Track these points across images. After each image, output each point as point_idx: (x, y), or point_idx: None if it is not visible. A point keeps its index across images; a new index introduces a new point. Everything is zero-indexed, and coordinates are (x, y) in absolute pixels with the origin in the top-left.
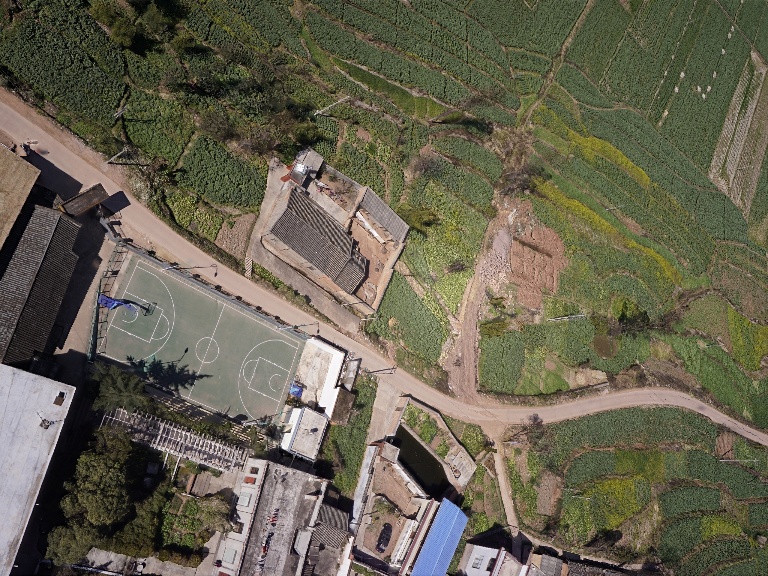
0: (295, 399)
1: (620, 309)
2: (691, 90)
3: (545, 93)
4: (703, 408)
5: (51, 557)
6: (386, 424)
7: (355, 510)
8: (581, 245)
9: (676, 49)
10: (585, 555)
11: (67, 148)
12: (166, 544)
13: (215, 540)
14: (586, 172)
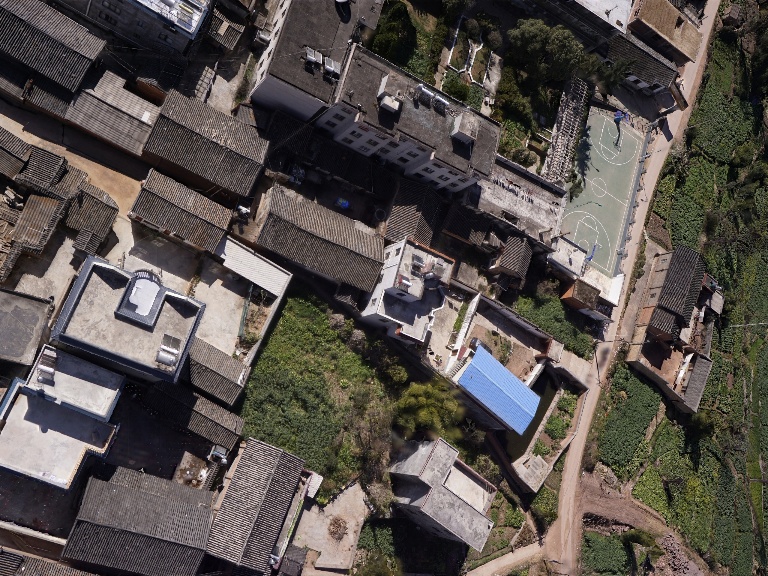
0: None
1: None
2: None
3: None
4: None
5: (514, 28)
6: None
7: None
8: None
9: None
10: None
11: None
12: None
13: None
14: None
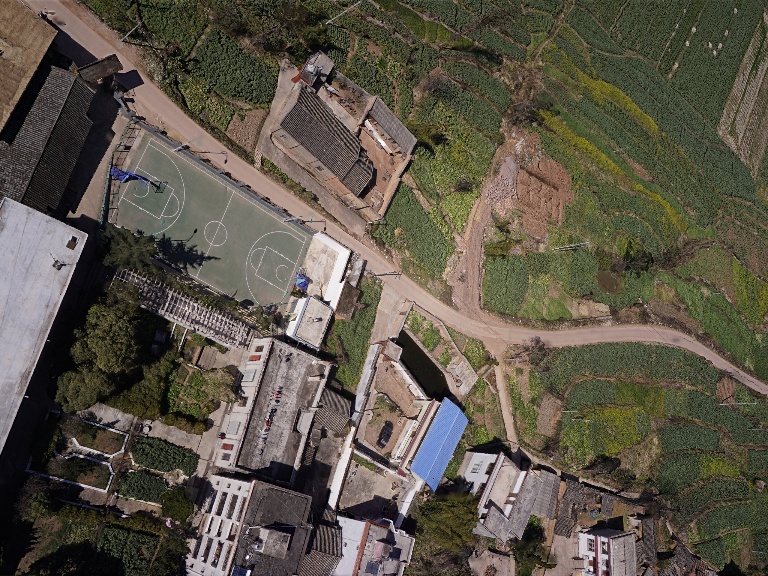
0: (301, 291)
1: (625, 247)
2: (702, 46)
3: (556, 33)
4: (705, 352)
5: (60, 403)
6: (390, 327)
7: (357, 403)
8: (587, 182)
9: (688, 4)
10: (583, 478)
11: (83, 22)
12: (172, 411)
13: (220, 413)
14: (594, 113)
